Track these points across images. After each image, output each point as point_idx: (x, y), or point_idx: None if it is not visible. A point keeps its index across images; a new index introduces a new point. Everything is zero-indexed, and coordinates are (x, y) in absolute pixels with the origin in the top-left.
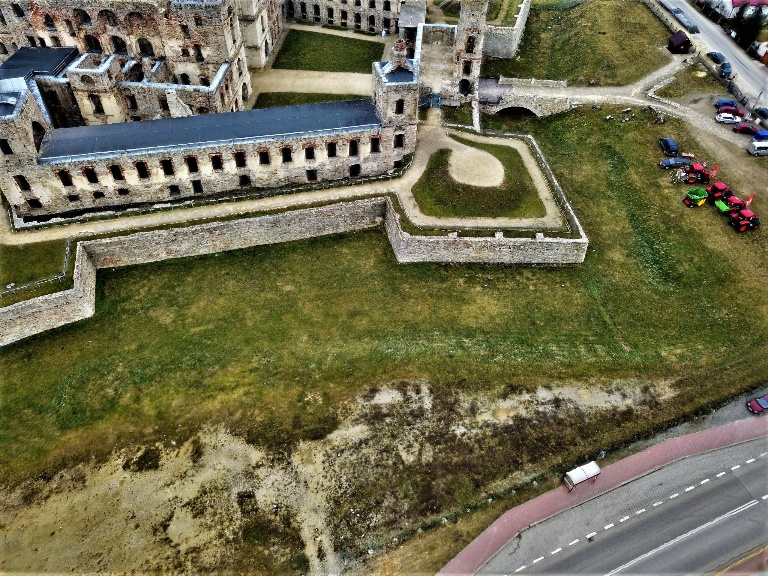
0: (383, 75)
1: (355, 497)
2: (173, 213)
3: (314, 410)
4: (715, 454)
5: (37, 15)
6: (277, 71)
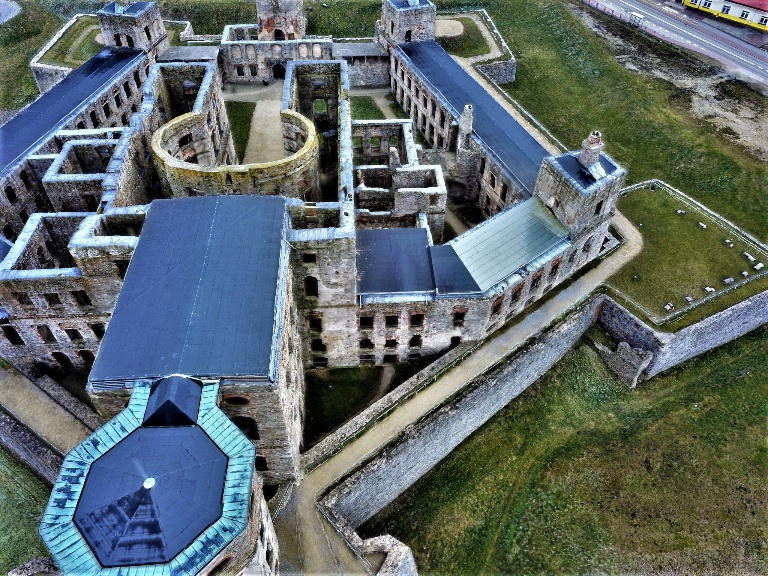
0: (419, 6)
1: (689, 71)
2: None
3: (657, 85)
4: (596, 0)
5: None
6: None
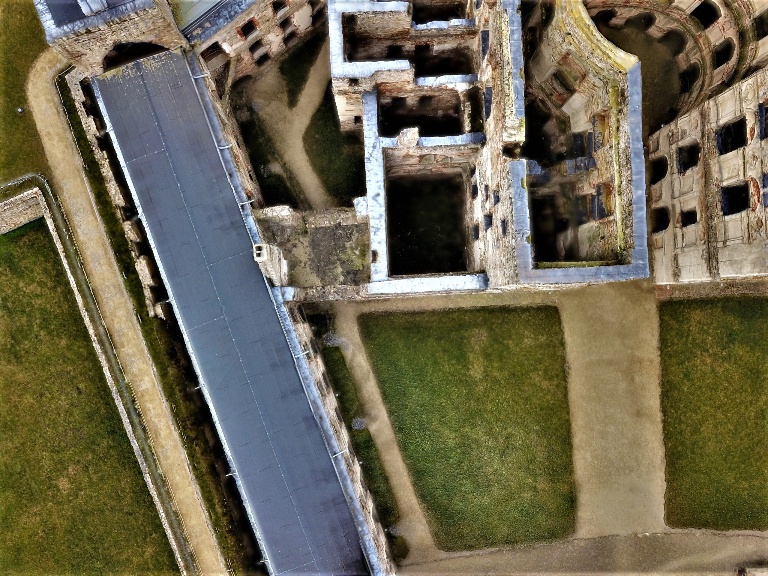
0: None
1: None
2: (121, 300)
3: None
4: None
5: None
6: (648, 316)
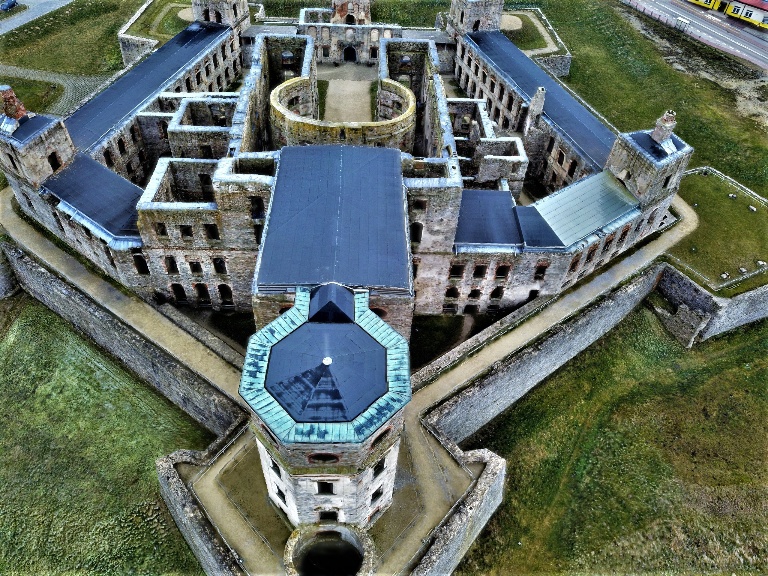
0: None
1: (733, 74)
2: None
3: (704, 84)
4: (642, 5)
5: None
6: None
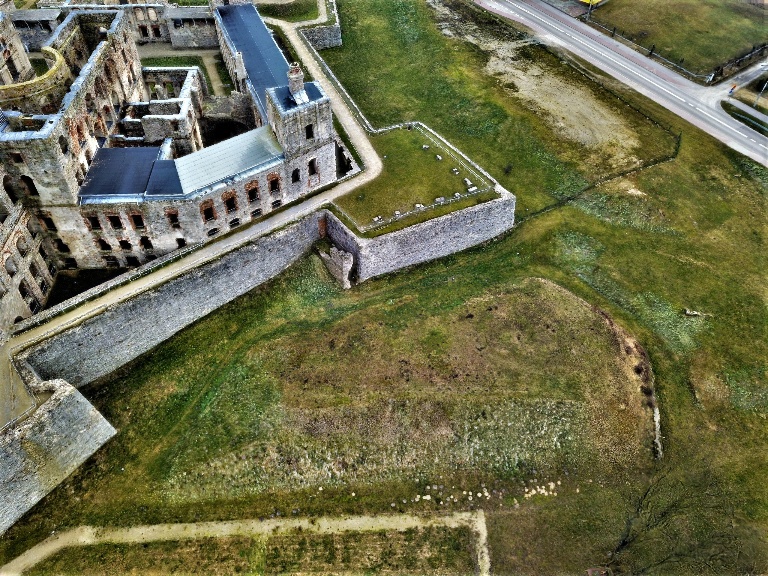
0: None
1: None
2: None
3: (463, 47)
4: None
5: (73, 134)
6: None
